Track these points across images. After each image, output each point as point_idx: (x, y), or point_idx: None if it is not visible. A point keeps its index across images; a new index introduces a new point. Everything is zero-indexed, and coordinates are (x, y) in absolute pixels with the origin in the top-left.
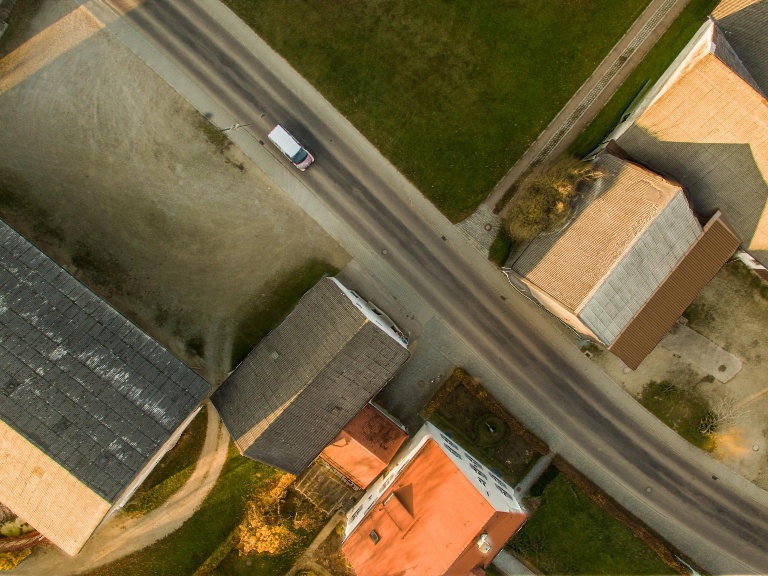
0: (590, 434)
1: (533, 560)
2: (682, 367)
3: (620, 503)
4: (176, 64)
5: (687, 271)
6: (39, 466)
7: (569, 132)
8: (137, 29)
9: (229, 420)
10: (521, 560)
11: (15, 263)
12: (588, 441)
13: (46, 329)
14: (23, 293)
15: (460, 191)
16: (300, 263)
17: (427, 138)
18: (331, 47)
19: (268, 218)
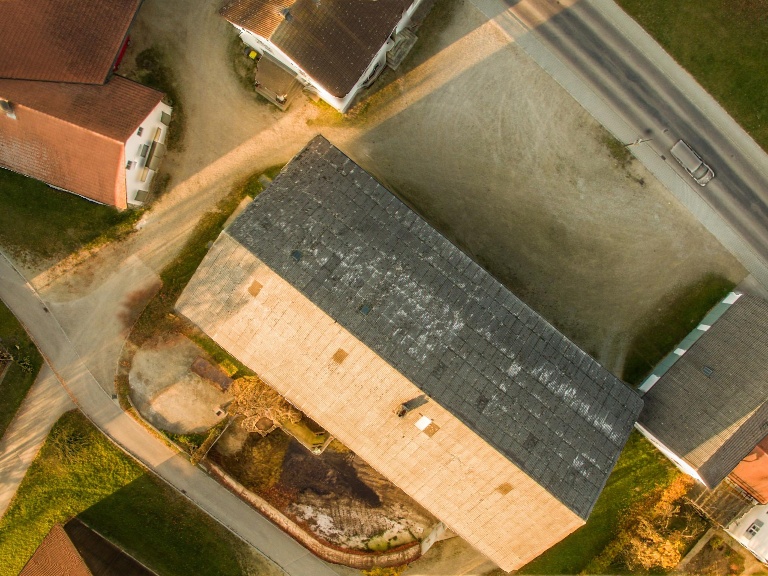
0: None
1: None
2: None
3: None
4: (582, 79)
5: None
6: (508, 483)
7: None
8: (545, 43)
9: (665, 436)
10: None
11: (461, 278)
12: None
13: (499, 345)
14: (474, 309)
15: None
16: (697, 278)
17: None
18: (737, 63)
19: (667, 233)
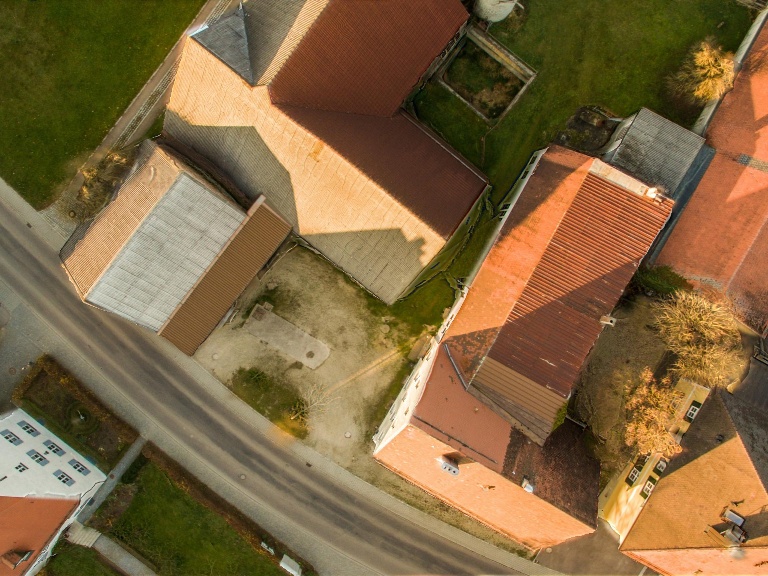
0: (182, 421)
1: (137, 547)
2: (270, 353)
3: (214, 490)
4: None
5: (235, 256)
6: None
7: (146, 118)
8: None
9: None
10: (125, 547)
11: None
12: (180, 428)
13: None
14: None
15: (41, 178)
16: None
17: (5, 125)
18: None
19: None
